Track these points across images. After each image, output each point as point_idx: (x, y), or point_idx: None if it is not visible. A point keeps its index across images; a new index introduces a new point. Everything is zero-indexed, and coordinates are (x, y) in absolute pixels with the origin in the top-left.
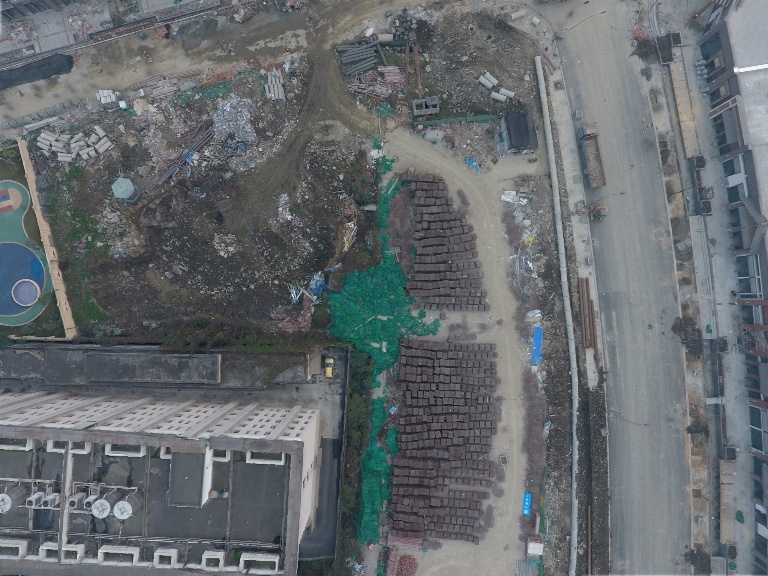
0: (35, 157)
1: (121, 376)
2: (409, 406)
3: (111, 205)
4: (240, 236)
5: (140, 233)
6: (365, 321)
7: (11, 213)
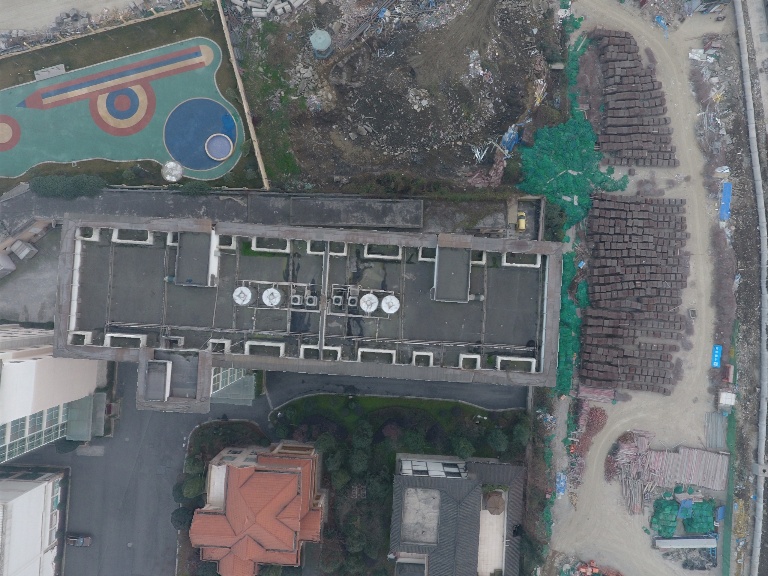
0: (228, 13)
1: (326, 220)
2: (602, 258)
3: (303, 61)
4: (433, 90)
5: (332, 89)
6: (556, 175)
7: (203, 69)
